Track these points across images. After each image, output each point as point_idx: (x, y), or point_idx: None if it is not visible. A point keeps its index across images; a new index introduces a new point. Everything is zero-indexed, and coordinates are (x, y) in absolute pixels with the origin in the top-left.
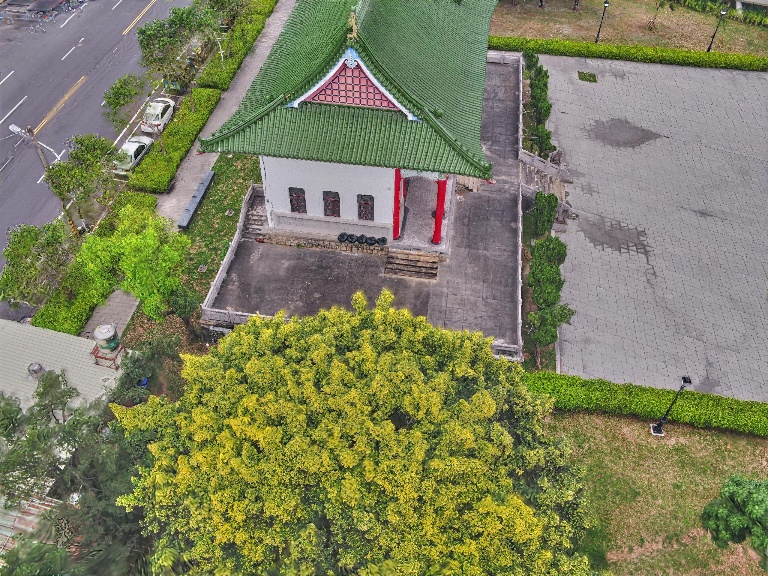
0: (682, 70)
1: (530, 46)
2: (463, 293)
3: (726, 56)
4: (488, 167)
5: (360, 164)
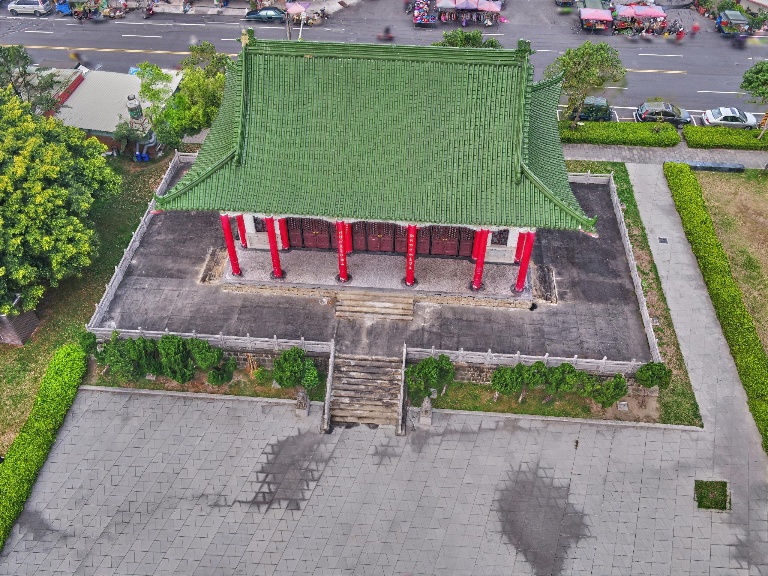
0: None
1: (759, 406)
2: (179, 301)
3: None
4: None
5: None
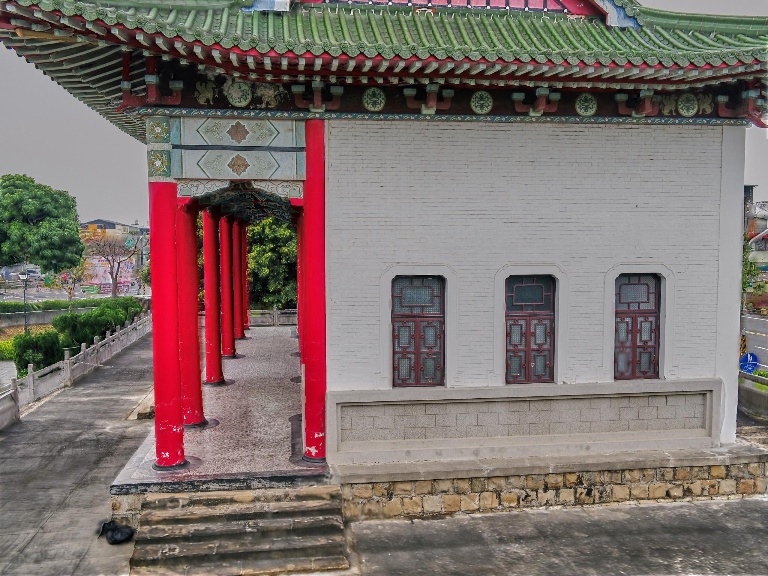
0: None
1: None
2: None
3: None
4: None
5: None
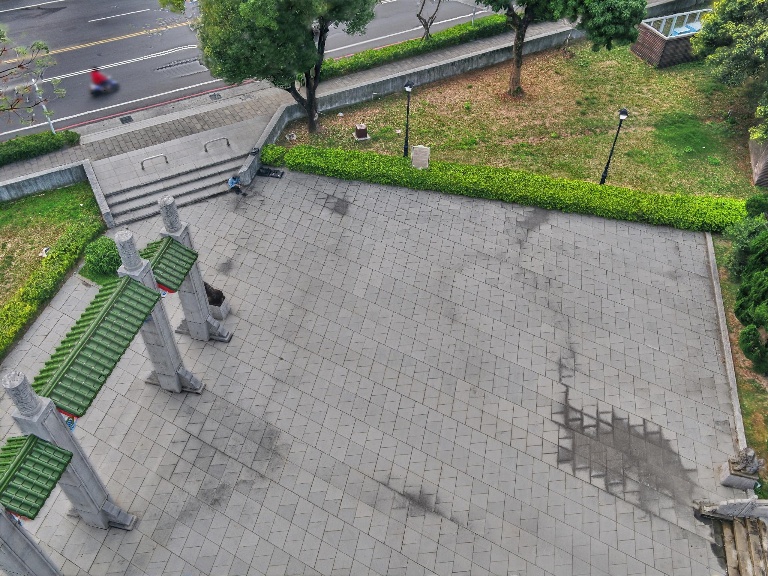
0: None
1: None
2: None
3: None
4: None
5: None
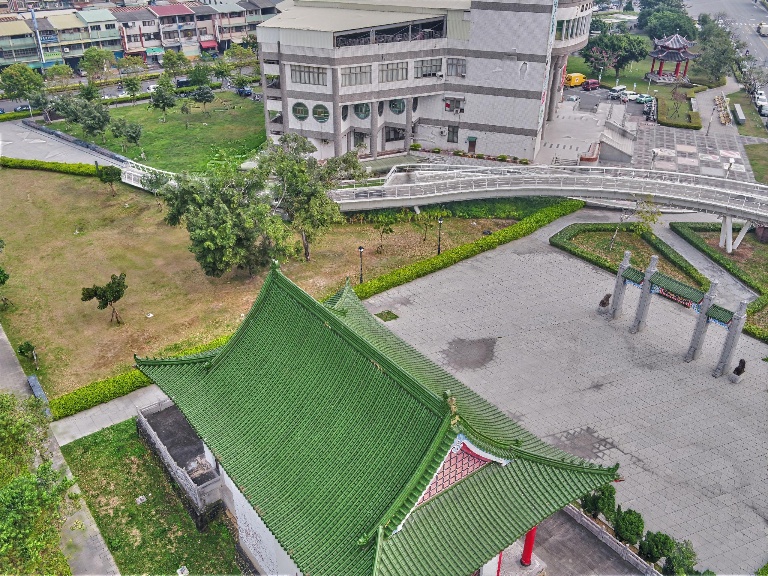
0: (438, 276)
1: None
2: None
3: (454, 252)
4: (616, 468)
5: (508, 545)
